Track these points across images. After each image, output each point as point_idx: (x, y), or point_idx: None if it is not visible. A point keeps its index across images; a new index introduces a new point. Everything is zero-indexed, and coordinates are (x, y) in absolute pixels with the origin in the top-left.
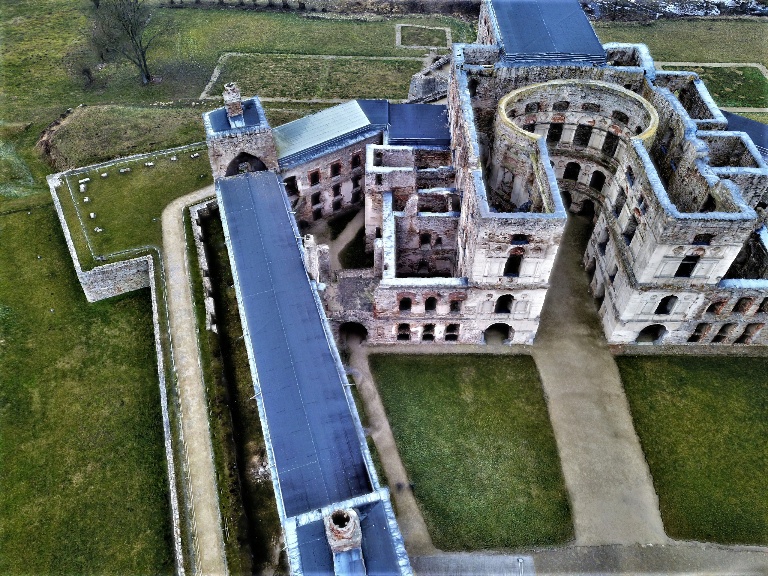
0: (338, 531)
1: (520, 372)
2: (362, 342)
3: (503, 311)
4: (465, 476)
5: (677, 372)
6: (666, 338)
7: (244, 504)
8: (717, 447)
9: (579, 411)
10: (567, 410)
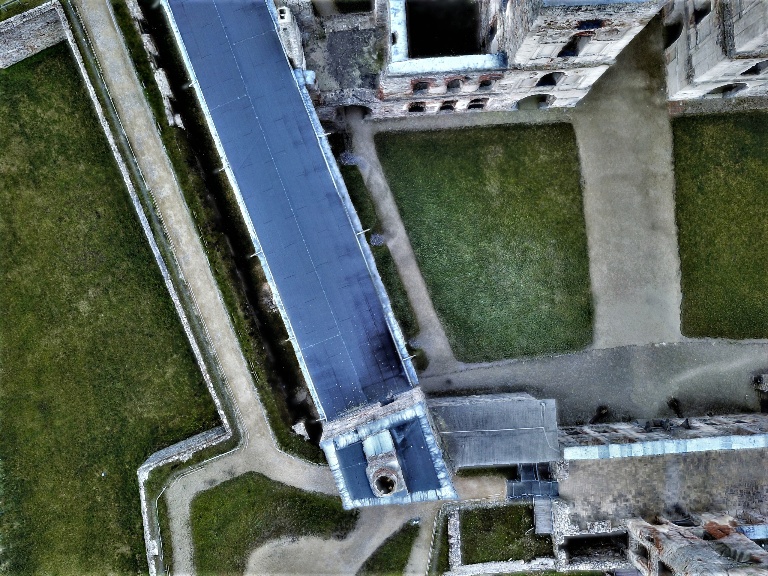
0: (383, 495)
1: (556, 149)
2: (365, 117)
3: (547, 83)
4: (487, 285)
5: (741, 137)
6: (742, 92)
7: (265, 340)
8: (759, 234)
9: (617, 198)
10: (604, 198)
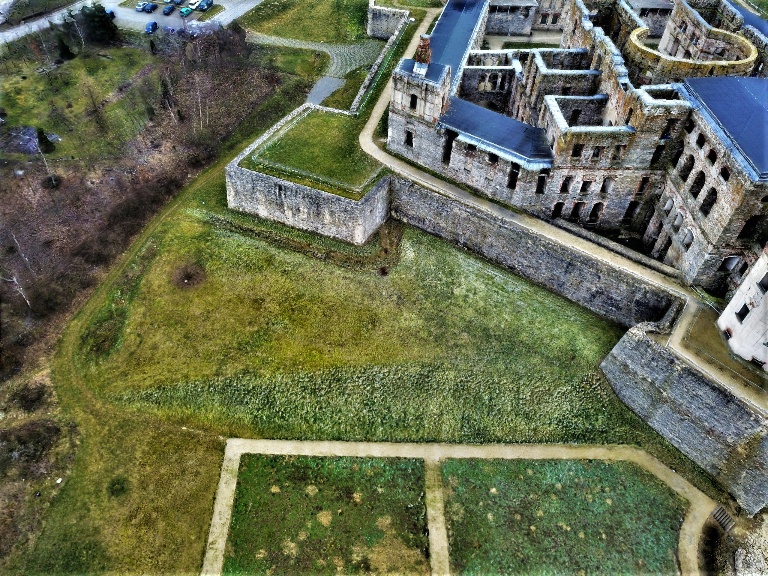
0: None
1: None
2: None
3: None
4: None
5: None
6: None
7: None
8: None
9: None
10: None
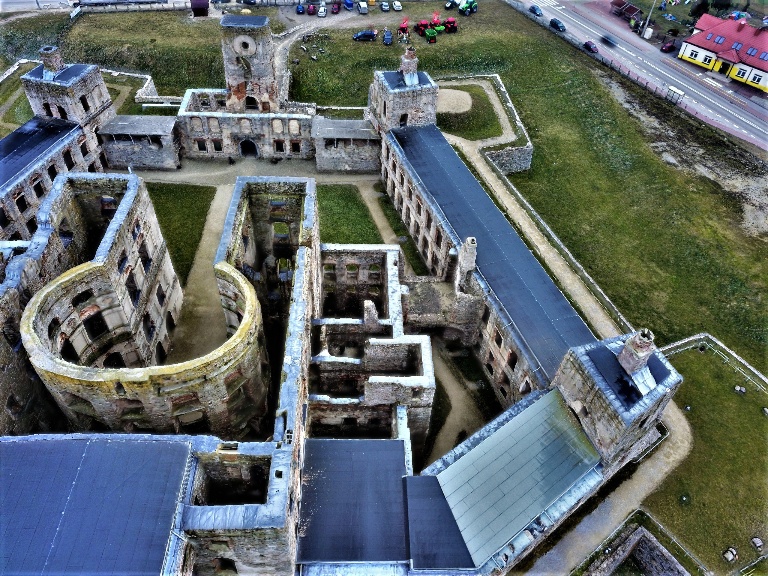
0: None
1: None
2: None
3: None
4: (333, 214)
5: None
6: None
7: None
8: None
9: None
10: None
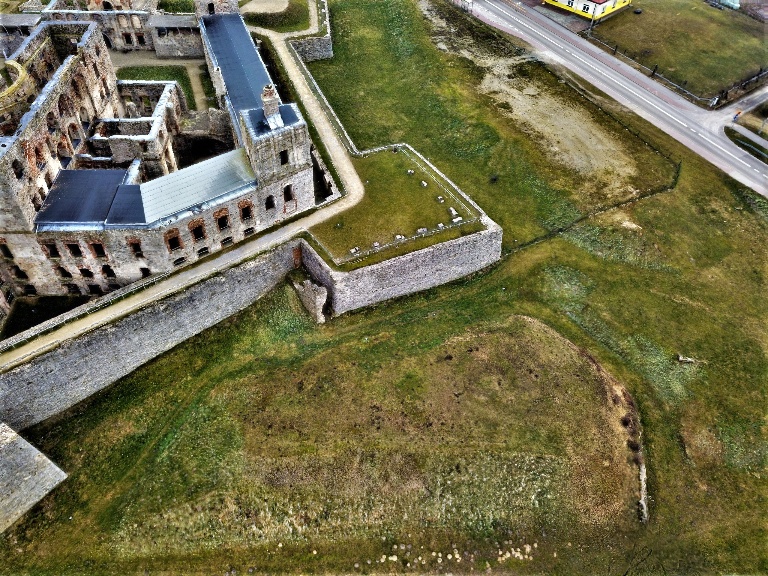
0: None
1: None
2: None
3: None
4: None
5: None
6: None
7: None
8: None
9: None
10: None
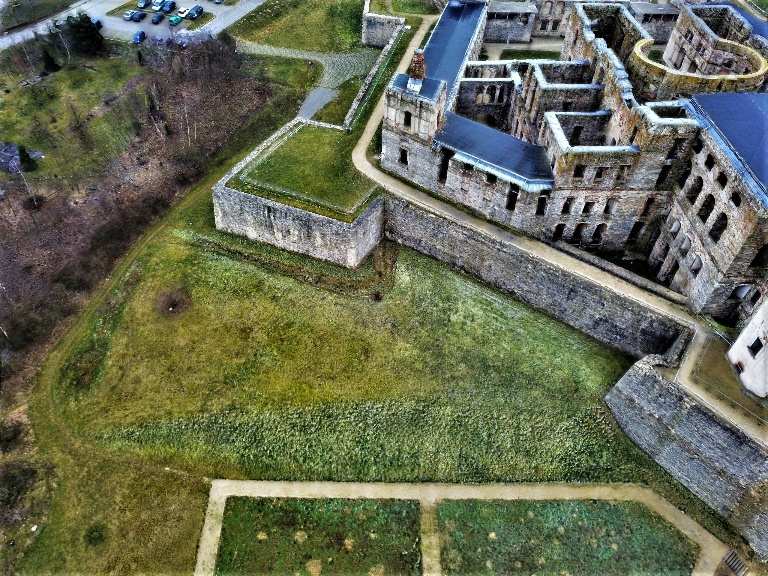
0: None
1: None
2: None
3: None
4: None
5: None
6: None
7: None
8: None
9: None
10: None
